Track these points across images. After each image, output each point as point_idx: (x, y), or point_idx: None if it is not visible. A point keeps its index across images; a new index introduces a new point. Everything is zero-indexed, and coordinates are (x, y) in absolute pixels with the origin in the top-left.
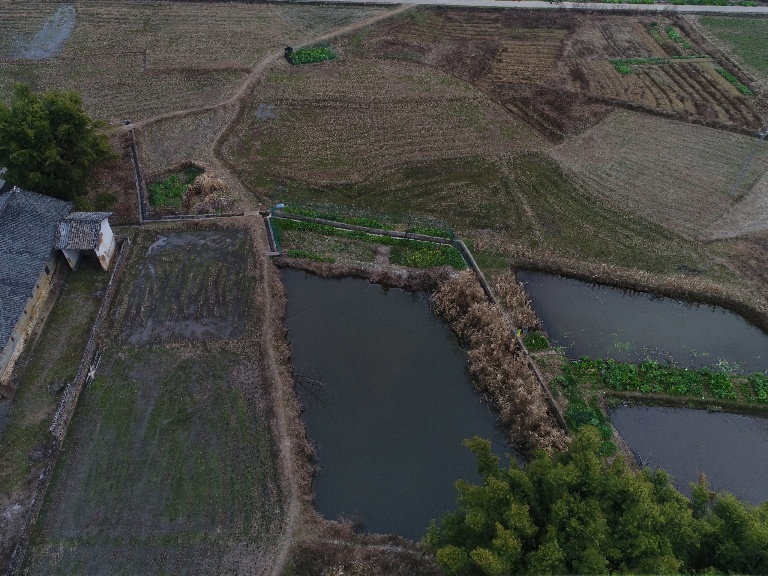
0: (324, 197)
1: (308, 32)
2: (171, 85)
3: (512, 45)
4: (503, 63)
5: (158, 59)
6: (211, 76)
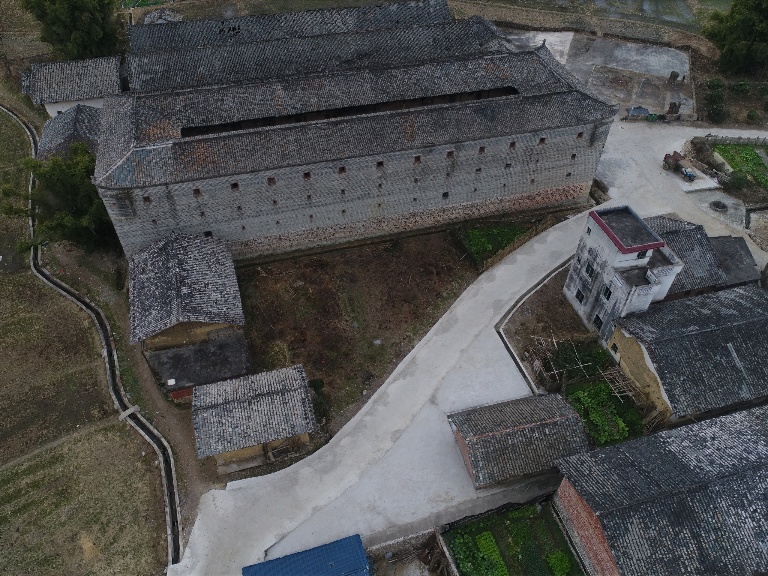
0: None
1: None
2: None
3: None
4: None
5: None
6: None
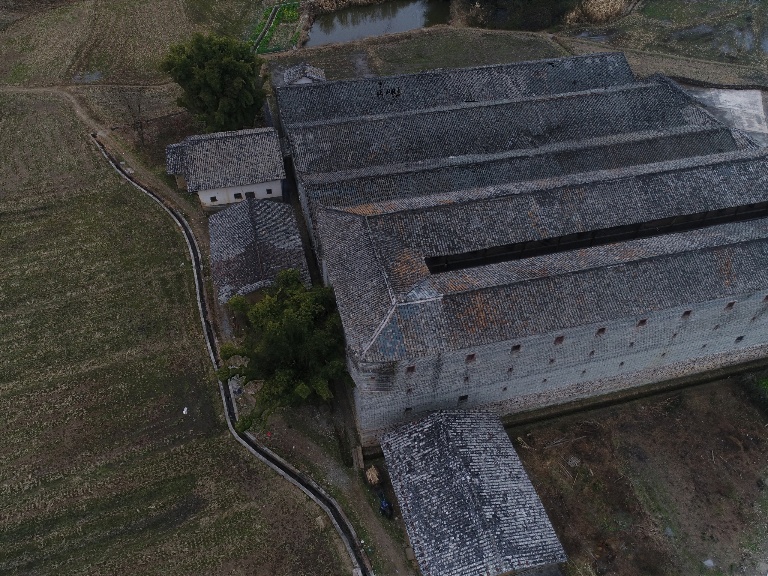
0: None
1: None
2: (4, 131)
3: None
4: None
5: None
6: None
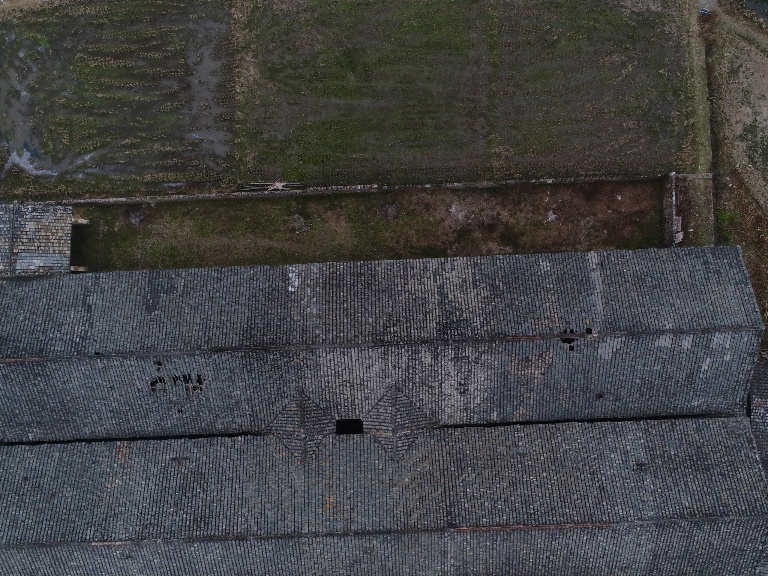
0: None
1: None
2: None
3: None
4: None
5: None
6: None
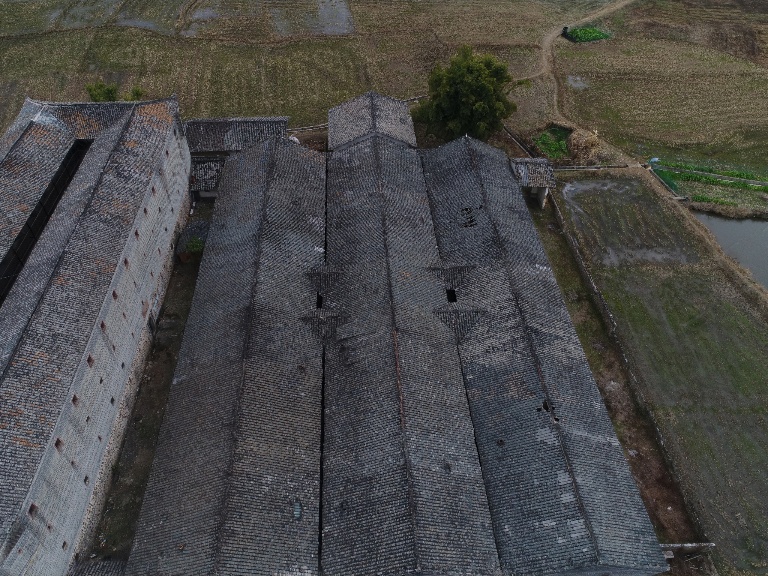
0: (685, 154)
1: (568, 14)
2: None
3: (764, 28)
4: (767, 44)
5: (448, 36)
6: (507, 51)
